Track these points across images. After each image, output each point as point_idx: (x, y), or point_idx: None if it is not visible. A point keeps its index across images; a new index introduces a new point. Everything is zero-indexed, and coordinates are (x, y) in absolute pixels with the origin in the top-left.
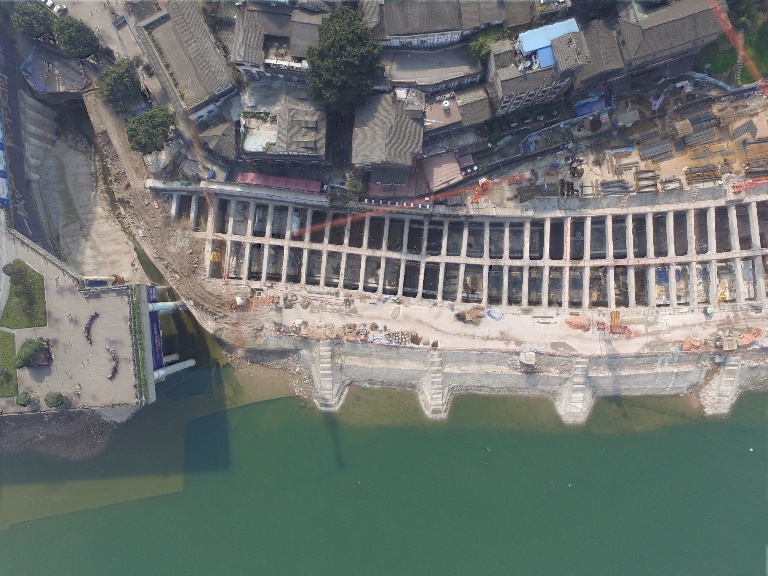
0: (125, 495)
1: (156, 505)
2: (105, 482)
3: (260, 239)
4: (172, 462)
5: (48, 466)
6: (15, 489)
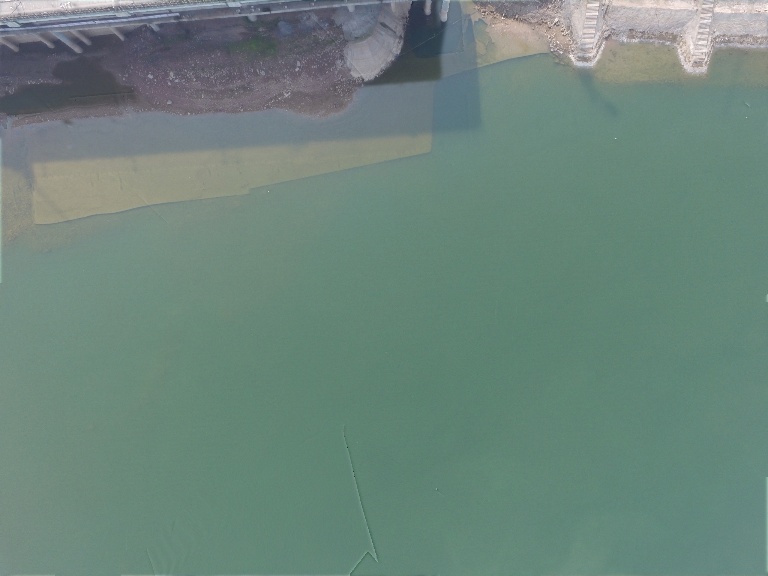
0: (371, 156)
1: (403, 166)
2: (350, 143)
3: None
4: (420, 122)
5: (290, 128)
6: (255, 152)
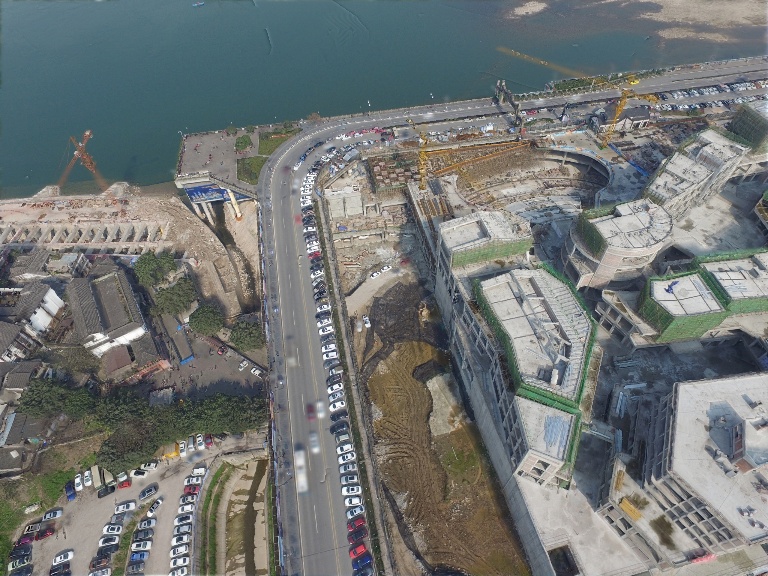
0: None
1: None
2: None
3: (124, 244)
4: None
5: None
6: None
